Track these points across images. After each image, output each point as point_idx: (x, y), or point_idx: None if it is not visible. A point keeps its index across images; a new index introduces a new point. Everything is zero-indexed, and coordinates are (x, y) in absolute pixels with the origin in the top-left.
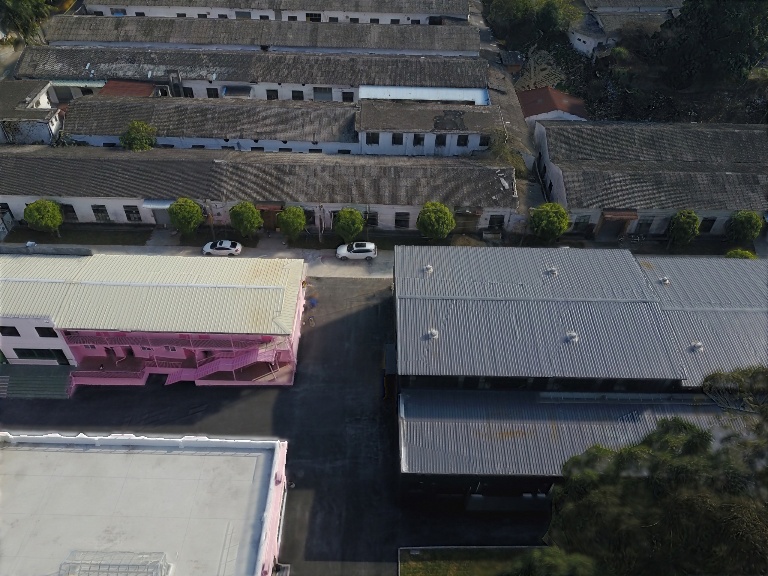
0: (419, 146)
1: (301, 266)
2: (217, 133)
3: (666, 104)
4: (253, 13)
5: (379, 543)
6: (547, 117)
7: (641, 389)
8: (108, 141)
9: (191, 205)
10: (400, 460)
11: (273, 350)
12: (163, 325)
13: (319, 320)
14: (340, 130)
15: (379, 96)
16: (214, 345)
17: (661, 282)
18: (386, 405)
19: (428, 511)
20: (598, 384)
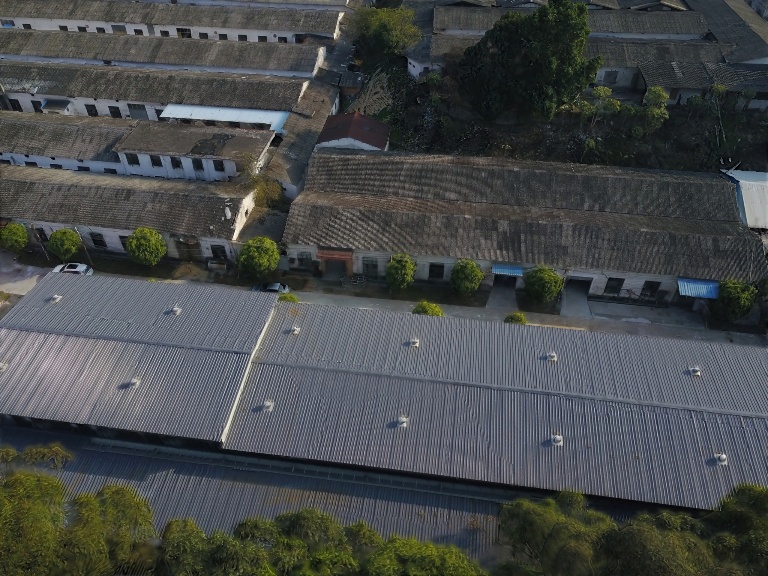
0: (179, 169)
1: None
2: None
3: (479, 135)
4: (127, 27)
5: None
6: (339, 144)
7: (191, 446)
8: None
9: None
10: None
11: None
12: None
13: None
14: (106, 149)
15: (180, 115)
16: None
17: (290, 332)
18: None
19: None
20: (144, 436)
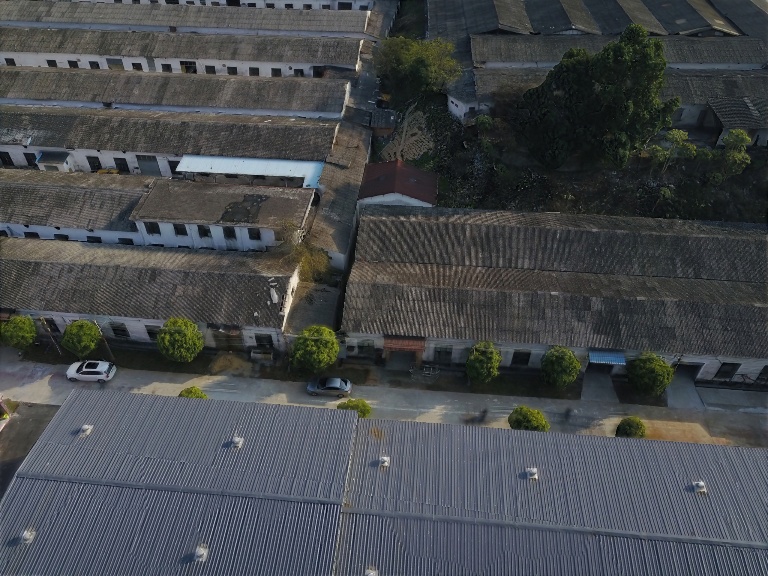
0: (207, 238)
1: None
2: None
3: (538, 184)
4: (124, 60)
5: None
6: (384, 200)
7: None
8: None
9: None
10: None
11: None
12: None
13: None
14: (120, 216)
15: (199, 169)
16: None
17: (378, 464)
18: None
19: None
20: None
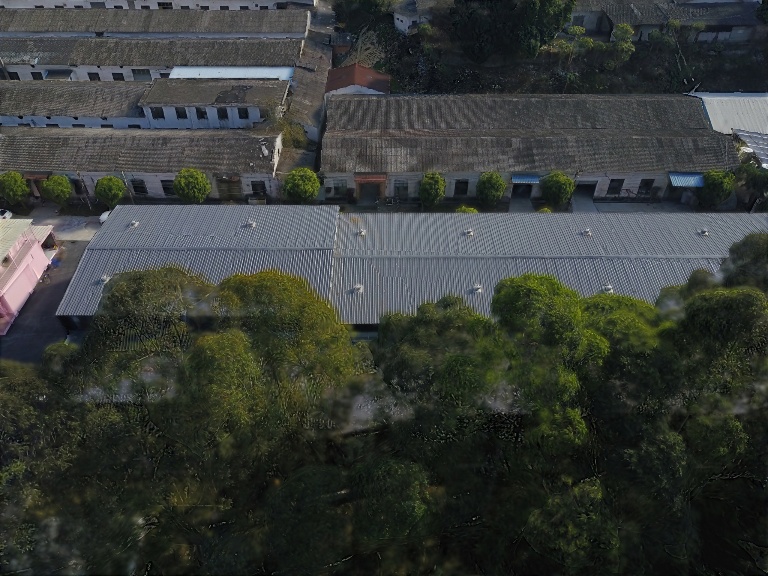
0: (204, 120)
1: (26, 225)
2: (11, 111)
3: (471, 78)
4: (107, 3)
5: None
6: (346, 92)
7: None
8: None
9: None
10: None
11: None
12: None
13: (57, 278)
14: (129, 106)
15: (188, 76)
16: None
17: (357, 234)
18: None
19: None
20: None
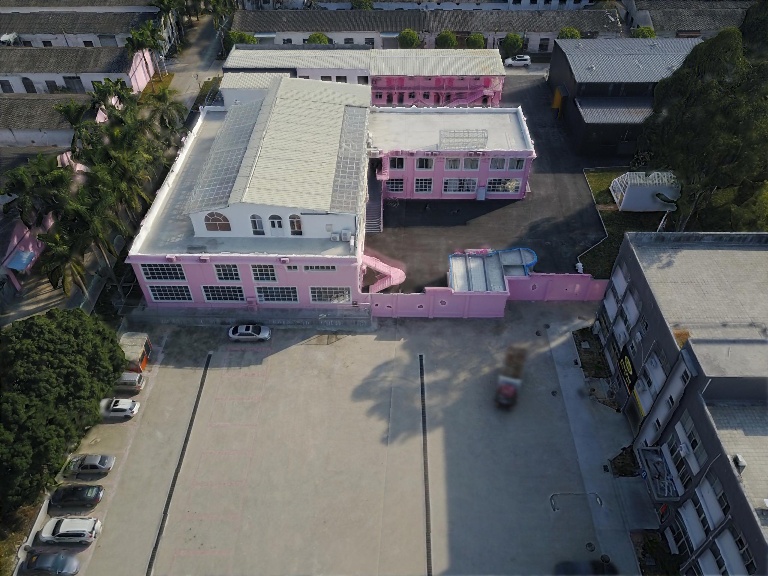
0: (548, 4)
1: None
2: None
3: None
4: None
5: (571, 167)
6: None
7: None
8: (340, 7)
9: (413, 33)
10: (584, 119)
11: (492, 90)
12: (431, 73)
13: (505, 91)
14: None
15: None
16: (456, 89)
17: None
18: (559, 121)
19: (595, 156)
20: None
